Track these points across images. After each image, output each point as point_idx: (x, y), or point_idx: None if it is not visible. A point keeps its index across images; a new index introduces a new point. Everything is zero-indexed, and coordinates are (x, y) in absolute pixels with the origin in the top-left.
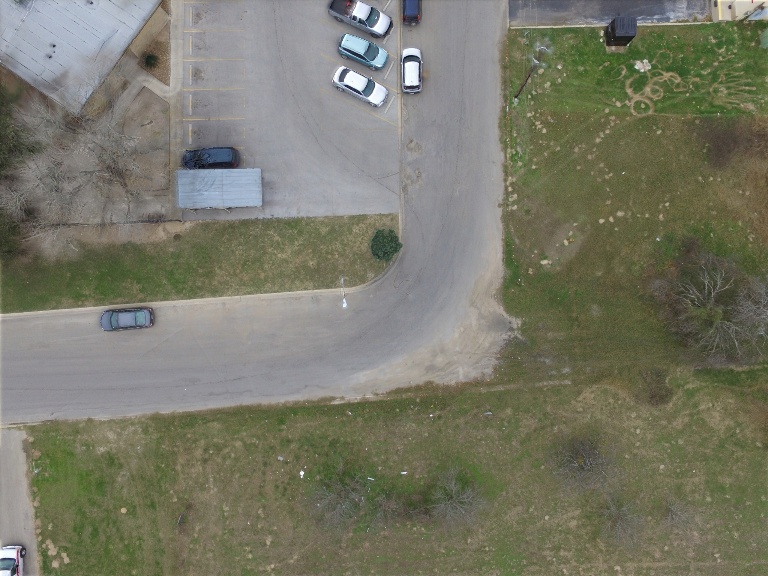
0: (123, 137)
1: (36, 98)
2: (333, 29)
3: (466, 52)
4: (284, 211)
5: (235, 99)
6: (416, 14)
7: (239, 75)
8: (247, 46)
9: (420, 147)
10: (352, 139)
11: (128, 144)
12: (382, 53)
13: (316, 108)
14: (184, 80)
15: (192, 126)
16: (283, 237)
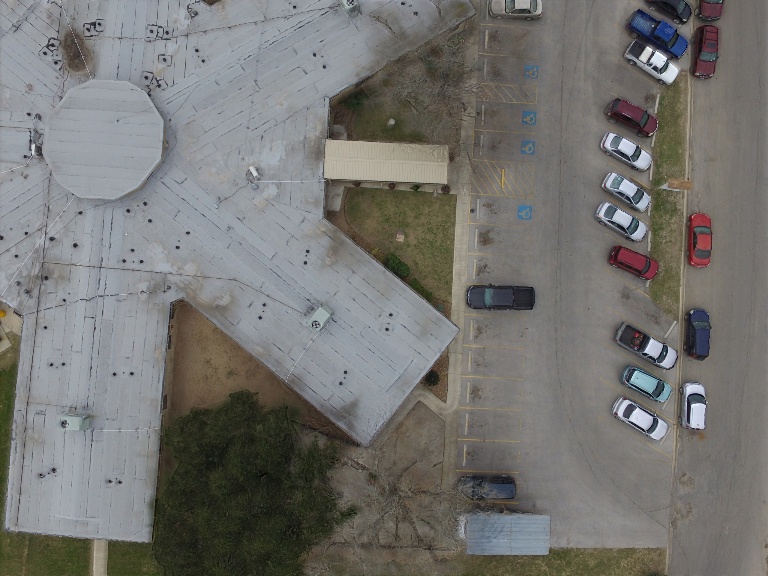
0: (450, 522)
1: (317, 417)
2: (614, 353)
3: (745, 387)
4: (554, 541)
5: (512, 421)
6: (707, 355)
7: (517, 396)
8: (526, 365)
9: (693, 482)
10: (626, 470)
11: (460, 537)
12: (667, 389)
13: (592, 435)
14: (461, 398)
15: (467, 447)
16: (551, 567)
